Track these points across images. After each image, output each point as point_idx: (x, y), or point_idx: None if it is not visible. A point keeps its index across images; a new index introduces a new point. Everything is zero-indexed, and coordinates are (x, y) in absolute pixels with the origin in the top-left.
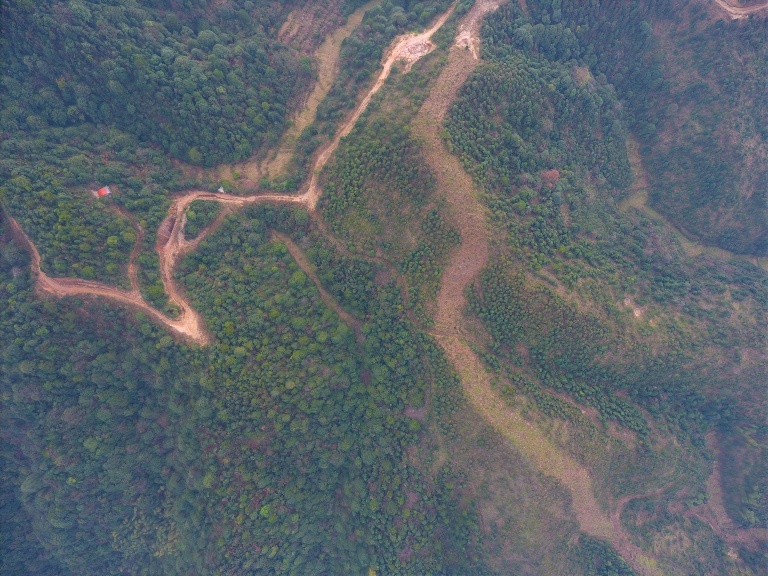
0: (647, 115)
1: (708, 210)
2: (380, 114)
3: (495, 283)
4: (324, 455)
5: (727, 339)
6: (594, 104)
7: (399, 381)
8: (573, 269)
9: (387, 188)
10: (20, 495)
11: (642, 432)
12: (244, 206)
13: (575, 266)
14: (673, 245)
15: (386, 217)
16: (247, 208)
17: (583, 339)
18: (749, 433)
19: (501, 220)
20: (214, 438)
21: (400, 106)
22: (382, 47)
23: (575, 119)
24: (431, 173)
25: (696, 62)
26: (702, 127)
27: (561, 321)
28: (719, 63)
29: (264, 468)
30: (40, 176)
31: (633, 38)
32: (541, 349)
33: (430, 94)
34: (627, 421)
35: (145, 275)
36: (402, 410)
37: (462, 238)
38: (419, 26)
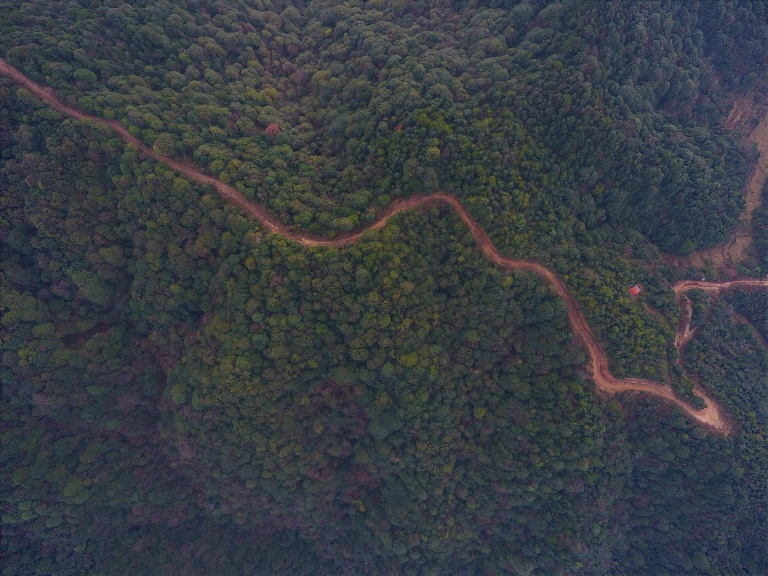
0: None
1: None
2: None
3: None
4: None
5: None
6: None
7: None
8: None
9: None
10: (470, 572)
11: None
12: (721, 292)
13: None
14: None
15: None
16: (729, 295)
17: None
18: None
19: None
20: (717, 521)
21: None
22: None
23: None
24: None
25: None
26: None
27: None
28: None
29: None
30: (609, 283)
31: None
32: None
33: None
34: None
35: (674, 369)
36: None
37: None
38: None
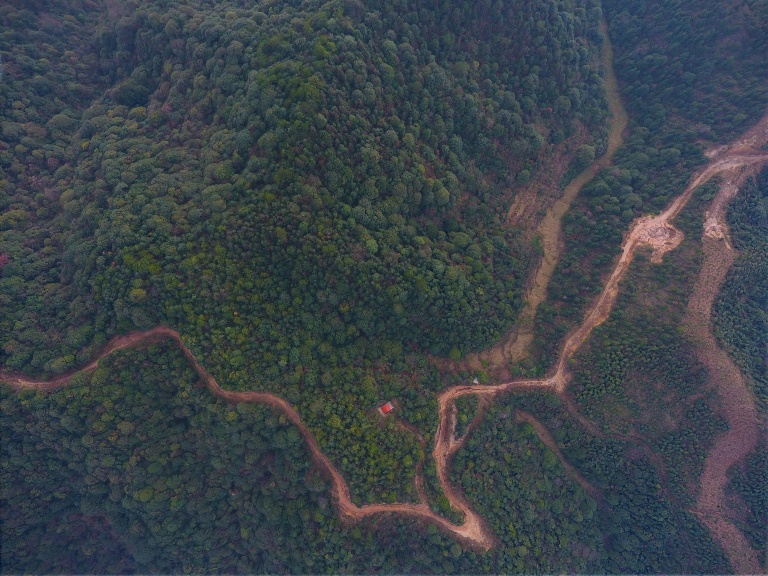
0: None
1: None
2: (641, 309)
3: (765, 467)
4: None
5: None
6: None
7: (649, 550)
8: None
9: (653, 380)
10: None
11: None
12: (497, 395)
13: None
14: None
15: (646, 404)
16: (503, 398)
17: None
18: None
19: None
20: None
21: (661, 300)
22: (620, 230)
23: None
24: (706, 371)
25: None
26: None
27: None
28: None
29: None
30: (344, 410)
31: None
32: None
33: (694, 290)
34: None
35: (430, 485)
36: None
37: (730, 425)
38: (654, 208)
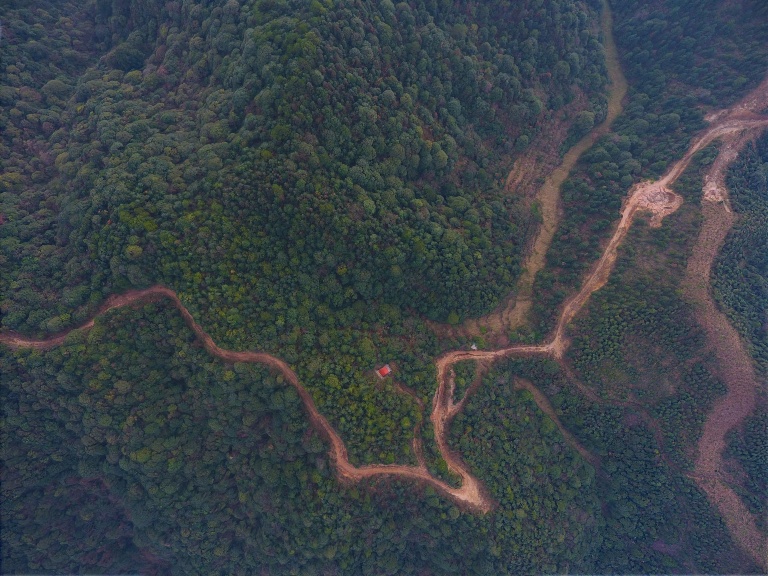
0: None
1: None
2: (640, 272)
3: (762, 430)
4: None
5: None
6: None
7: (647, 516)
8: None
9: (651, 344)
10: None
11: None
12: (495, 361)
13: None
14: None
15: (644, 368)
16: (501, 364)
17: None
18: None
19: (767, 370)
20: None
21: (660, 264)
22: (619, 196)
23: None
24: (704, 333)
25: None
26: None
27: None
28: None
29: None
30: (342, 370)
31: None
32: None
33: (693, 253)
34: None
35: (428, 448)
36: None
37: None
38: (654, 173)
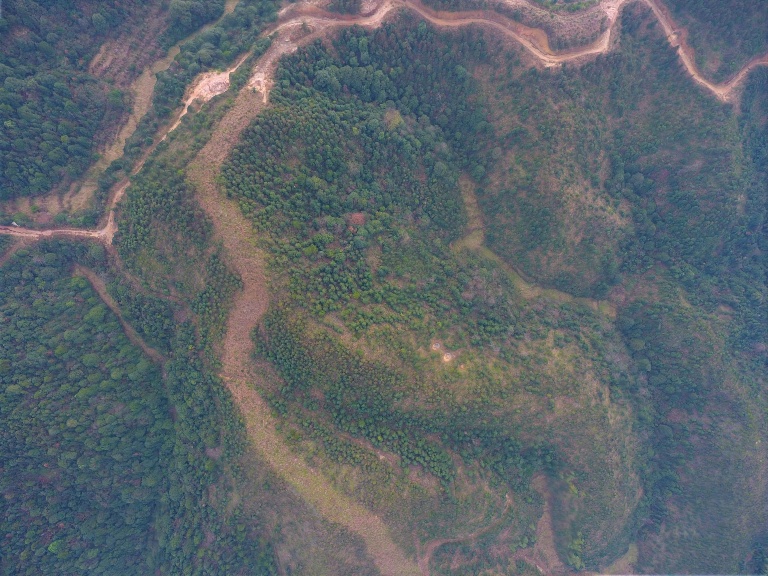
0: (478, 156)
1: (538, 254)
2: (165, 155)
3: (276, 329)
4: (123, 491)
5: (540, 386)
6: (407, 147)
7: (199, 420)
8: (366, 315)
9: (170, 229)
10: None
11: (445, 478)
12: (39, 240)
13: (369, 312)
14: (498, 288)
15: (174, 257)
16: (40, 243)
17: (373, 386)
18: (570, 479)
19: (282, 266)
20: None
21: (184, 147)
22: (185, 84)
23: (390, 161)
24: (205, 218)
25: (515, 107)
26: (525, 172)
27: (346, 368)
28: (535, 110)
29: (59, 503)
30: None
31: (453, 81)
32: (333, 394)
33: (211, 137)
34: (430, 467)
35: None
36: (203, 448)
37: (243, 282)
38: (223, 64)
